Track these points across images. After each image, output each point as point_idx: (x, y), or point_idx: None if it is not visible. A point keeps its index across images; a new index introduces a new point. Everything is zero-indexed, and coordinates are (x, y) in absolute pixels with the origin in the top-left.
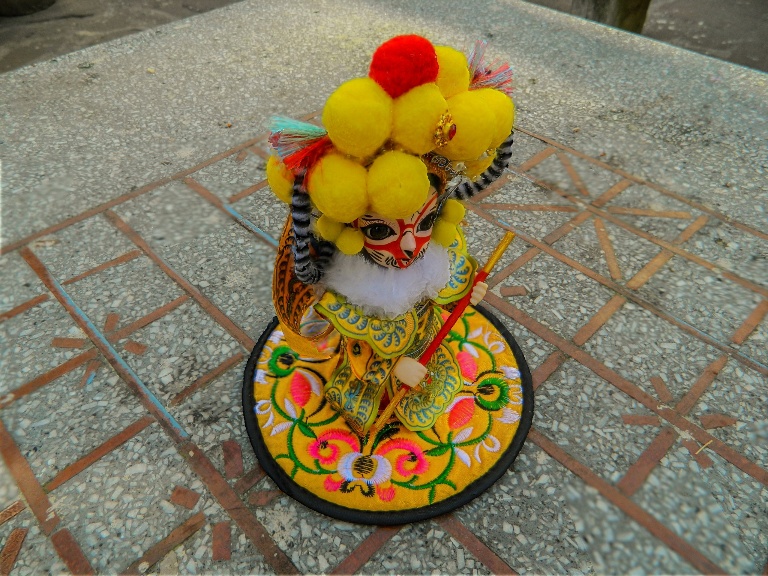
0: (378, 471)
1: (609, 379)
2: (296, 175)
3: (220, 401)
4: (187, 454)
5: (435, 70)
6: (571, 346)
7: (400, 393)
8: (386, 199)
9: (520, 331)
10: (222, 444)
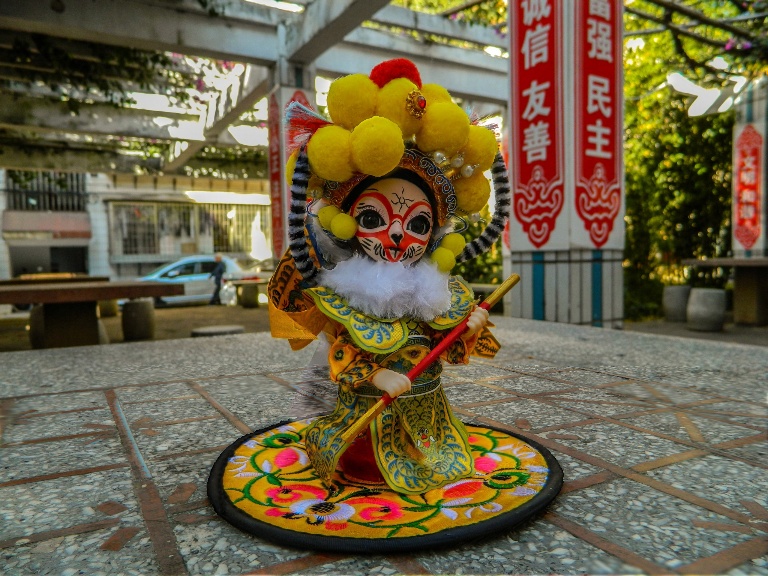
0: (336, 512)
1: (676, 494)
2: (302, 148)
3: (201, 463)
4: (140, 486)
5: (413, 74)
6: (627, 470)
7: (376, 404)
8: (361, 137)
9: (562, 457)
10: (180, 484)
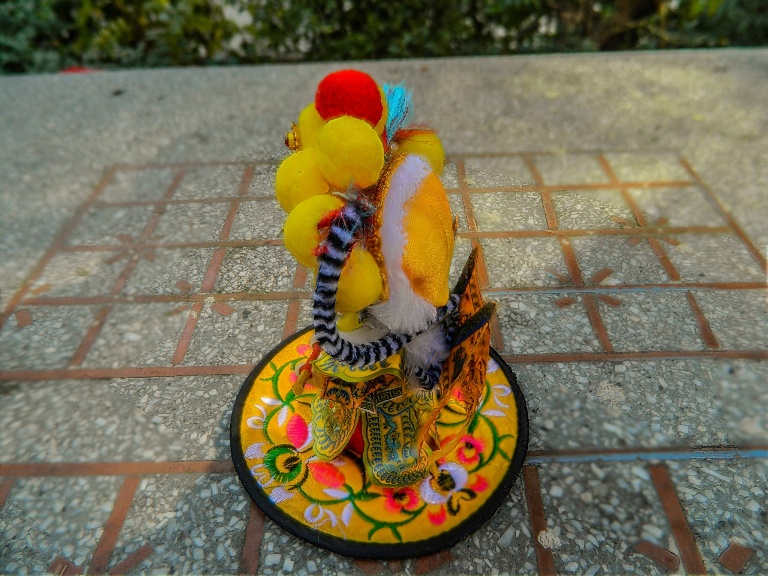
0: (320, 355)
1: None
2: None
3: None
4: None
5: None
6: None
7: None
8: None
9: (309, 570)
10: None
